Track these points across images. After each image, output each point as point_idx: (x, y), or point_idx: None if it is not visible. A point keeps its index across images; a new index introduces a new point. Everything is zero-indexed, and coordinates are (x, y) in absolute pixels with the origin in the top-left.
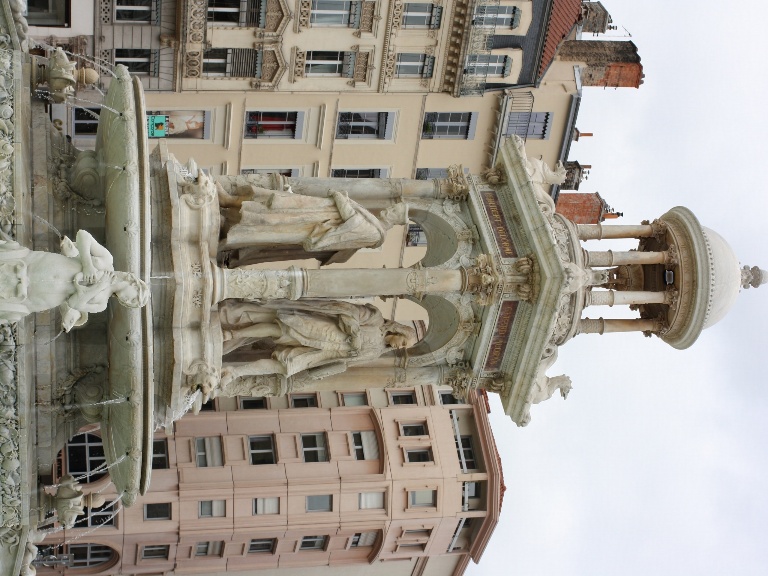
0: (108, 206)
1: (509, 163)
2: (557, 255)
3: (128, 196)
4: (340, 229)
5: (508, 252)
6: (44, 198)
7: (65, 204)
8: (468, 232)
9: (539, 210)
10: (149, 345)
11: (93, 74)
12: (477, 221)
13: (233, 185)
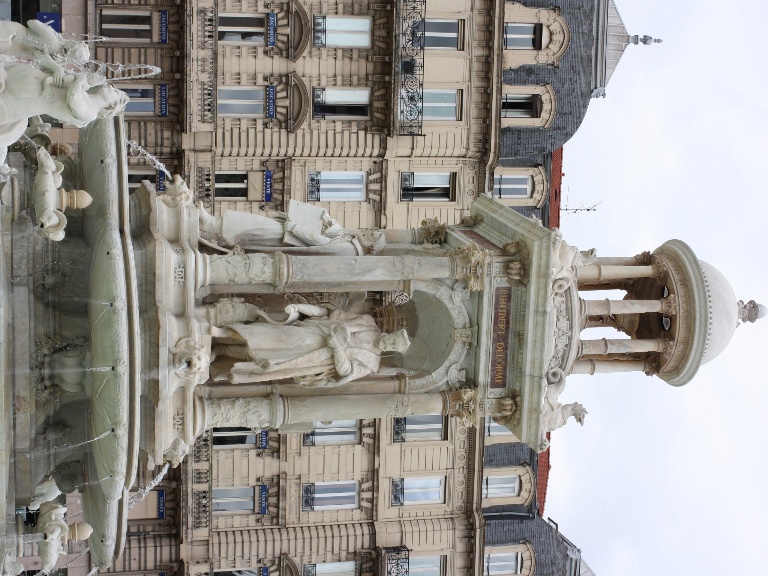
0: None
1: (536, 270)
2: (539, 423)
3: (113, 490)
4: (331, 385)
5: (498, 380)
6: (26, 431)
7: (48, 402)
8: (468, 334)
9: (543, 357)
10: (123, 535)
11: (86, 205)
12: (480, 328)
13: (232, 281)
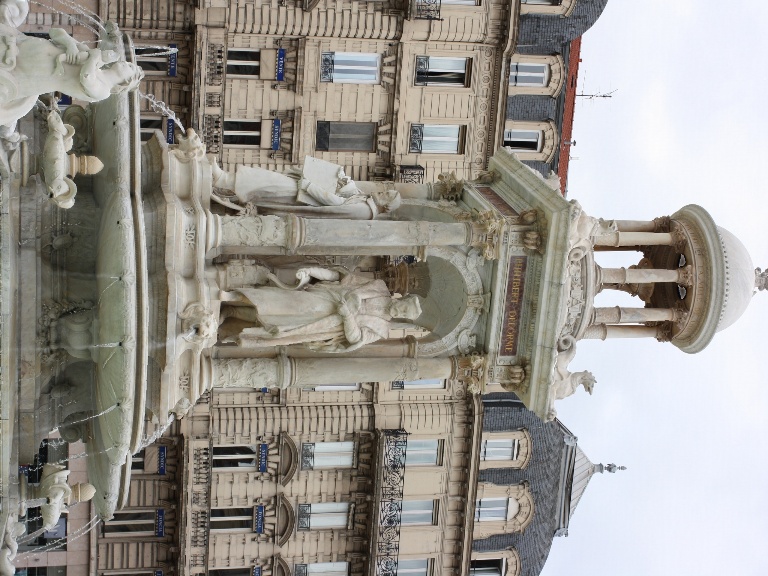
0: (98, 401)
1: (553, 242)
2: (548, 393)
3: (117, 458)
4: (340, 351)
5: (508, 348)
6: (31, 395)
7: (53, 364)
8: (480, 300)
9: (555, 328)
10: (125, 492)
11: (96, 171)
12: (493, 295)
13: (243, 243)
